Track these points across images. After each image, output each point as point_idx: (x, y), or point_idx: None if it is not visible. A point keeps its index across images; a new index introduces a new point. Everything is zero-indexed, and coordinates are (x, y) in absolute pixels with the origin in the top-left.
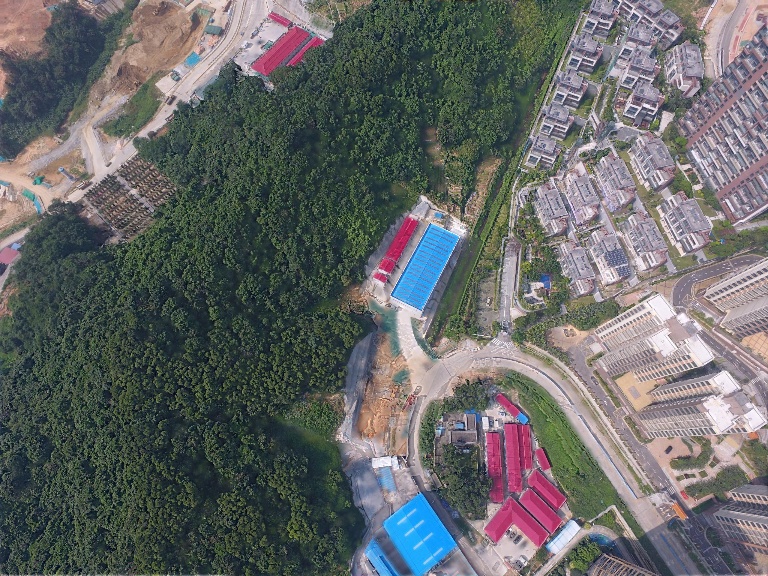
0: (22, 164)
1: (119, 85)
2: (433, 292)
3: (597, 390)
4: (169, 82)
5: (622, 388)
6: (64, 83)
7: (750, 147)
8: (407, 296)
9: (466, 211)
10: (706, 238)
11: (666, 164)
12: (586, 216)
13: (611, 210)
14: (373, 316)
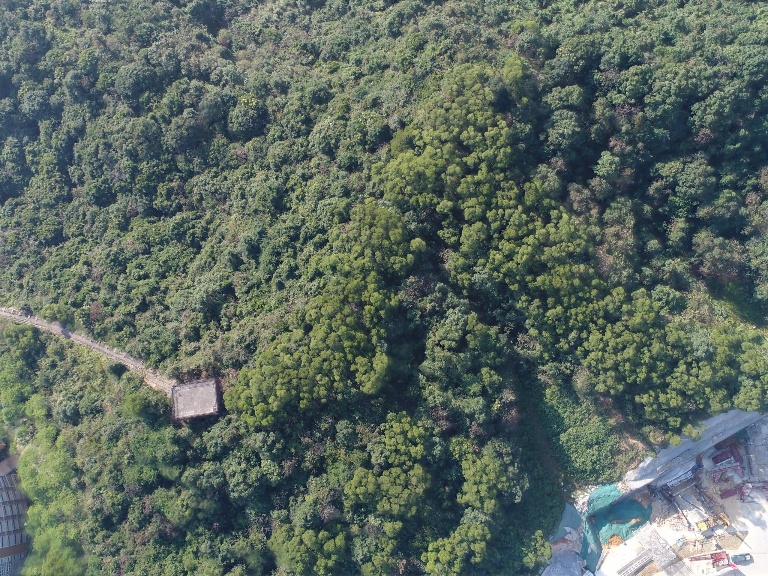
0: None
1: None
2: None
3: None
4: None
5: None
6: None
7: None
8: None
9: None
10: None
11: None
12: None
13: None
14: None
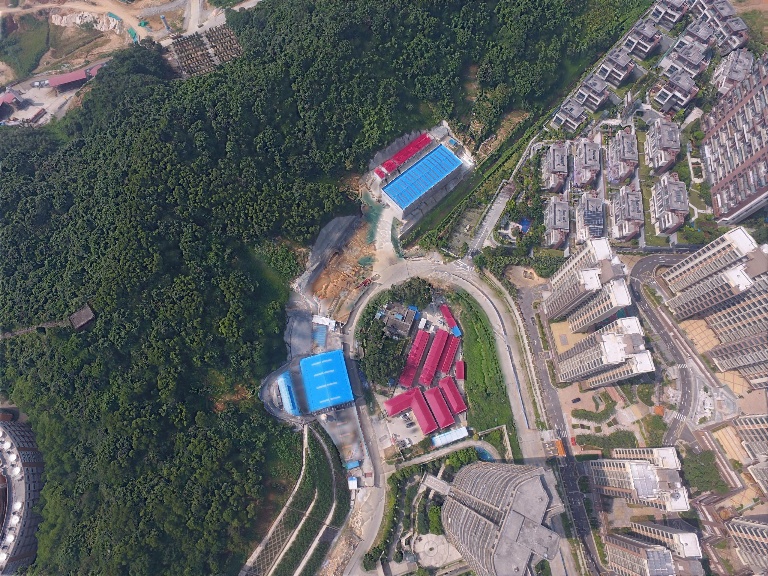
0: (136, 8)
1: None
2: (420, 200)
3: (532, 330)
4: None
5: (554, 332)
6: None
7: (751, 142)
8: (395, 194)
9: (480, 148)
10: (680, 218)
11: (671, 146)
12: (583, 178)
13: (609, 179)
14: (362, 205)
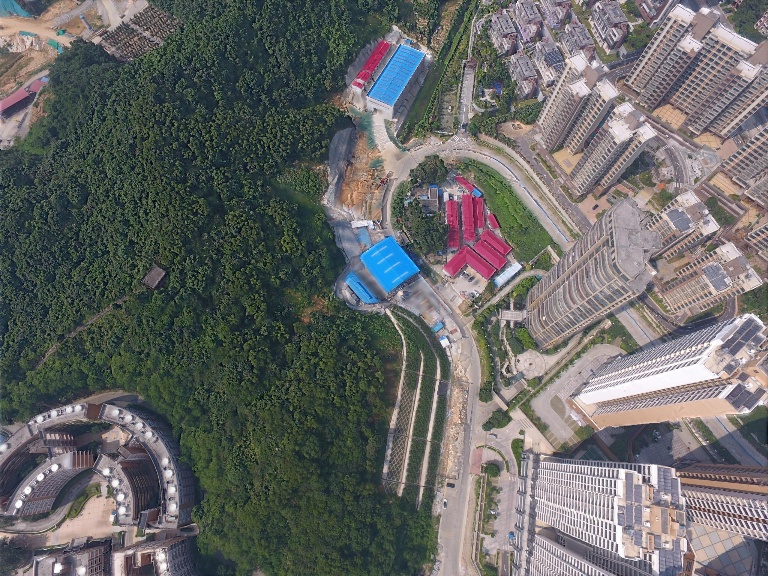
0: (46, 20)
1: None
2: (402, 95)
3: (538, 167)
4: None
5: (558, 160)
6: None
7: None
8: (380, 96)
9: (432, 41)
10: (624, 29)
11: None
12: (531, 32)
13: (552, 26)
14: (352, 118)
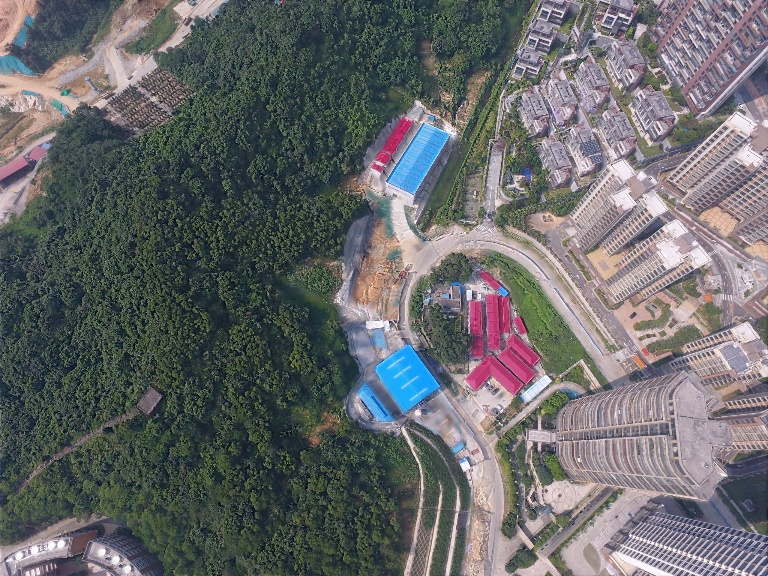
0: (50, 78)
1: (139, 11)
2: (424, 181)
3: (571, 266)
4: (186, 7)
5: (592, 261)
6: (89, 7)
7: (709, 38)
8: (401, 182)
9: (457, 117)
10: (670, 124)
11: (637, 62)
12: (565, 115)
13: (588, 110)
14: (370, 203)
